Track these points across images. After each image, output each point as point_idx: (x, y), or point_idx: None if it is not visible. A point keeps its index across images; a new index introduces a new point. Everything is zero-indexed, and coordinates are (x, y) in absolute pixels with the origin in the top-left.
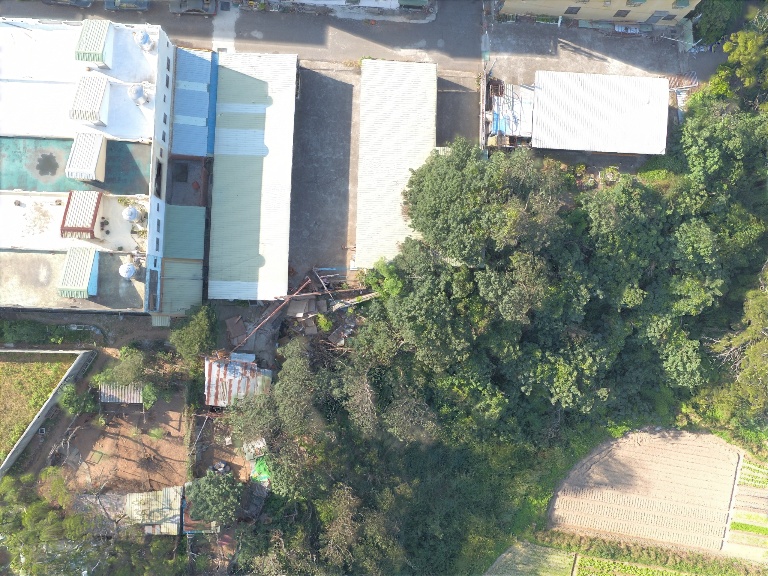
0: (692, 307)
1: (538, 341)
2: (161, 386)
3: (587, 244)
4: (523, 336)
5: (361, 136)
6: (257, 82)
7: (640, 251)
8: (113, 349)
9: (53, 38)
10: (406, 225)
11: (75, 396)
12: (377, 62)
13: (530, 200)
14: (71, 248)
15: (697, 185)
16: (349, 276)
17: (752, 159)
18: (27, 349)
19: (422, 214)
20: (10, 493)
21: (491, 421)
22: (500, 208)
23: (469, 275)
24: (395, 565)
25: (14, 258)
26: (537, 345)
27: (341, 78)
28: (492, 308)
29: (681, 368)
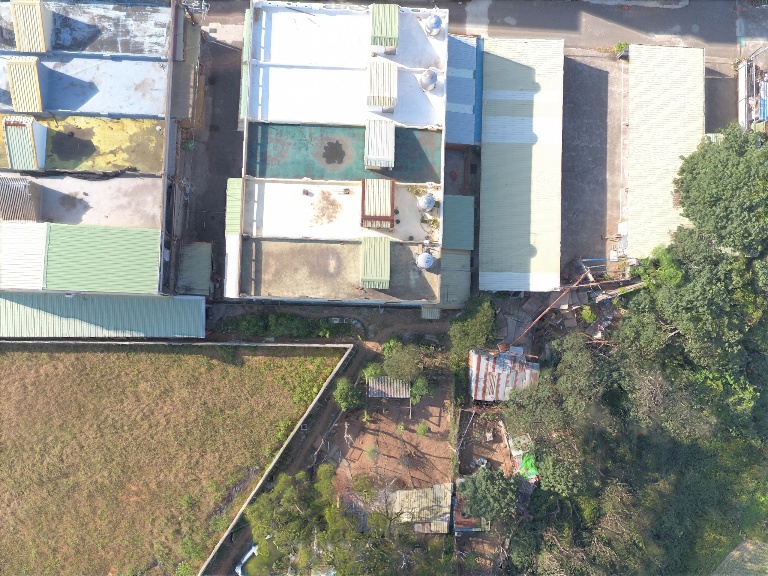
0: None
1: None
2: None
3: None
4: None
5: (631, 123)
6: (524, 68)
7: None
8: (373, 343)
9: (336, 23)
10: (677, 214)
11: (350, 391)
12: (644, 47)
13: None
14: (365, 238)
15: None
16: (609, 267)
17: None
18: (292, 343)
19: (699, 202)
20: (290, 490)
21: (740, 415)
22: None
23: None
24: None
25: (303, 249)
26: None
27: (596, 65)
28: (764, 298)
29: None
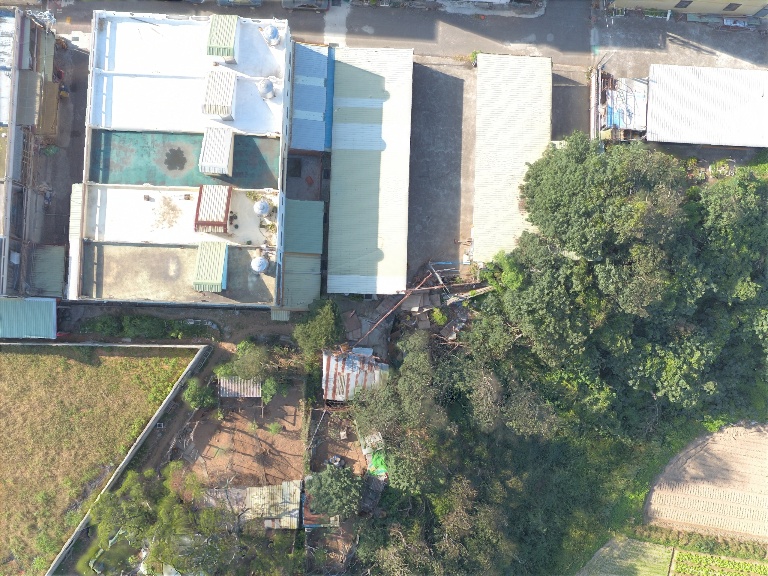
0: None
1: (646, 335)
2: (276, 380)
3: (700, 237)
4: None
5: (478, 130)
6: (374, 77)
7: (750, 244)
8: (229, 344)
9: (180, 33)
10: (523, 219)
11: (198, 390)
12: (492, 56)
13: (650, 193)
14: (202, 242)
15: None
16: (462, 270)
17: None
18: (146, 344)
19: (541, 208)
20: (136, 487)
21: (598, 415)
22: (623, 201)
23: (587, 268)
24: None
25: (144, 252)
26: (646, 339)
27: (452, 73)
28: (608, 301)
29: None
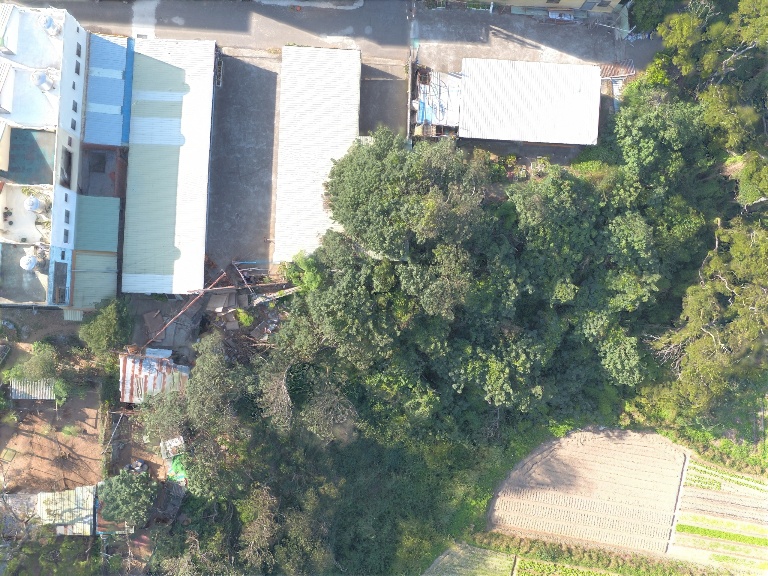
0: (627, 303)
1: (470, 337)
2: (77, 382)
3: (517, 237)
4: (456, 332)
5: (281, 125)
6: (174, 69)
7: (573, 245)
8: (27, 344)
9: None
10: (327, 217)
11: None
12: (298, 49)
13: (453, 191)
14: None
15: (631, 176)
16: (272, 270)
17: (692, 150)
18: None
19: (342, 205)
20: None
21: (422, 419)
22: (420, 199)
23: (391, 269)
24: (326, 567)
25: None
26: (468, 341)
27: (265, 66)
28: (416, 303)
29: (619, 366)
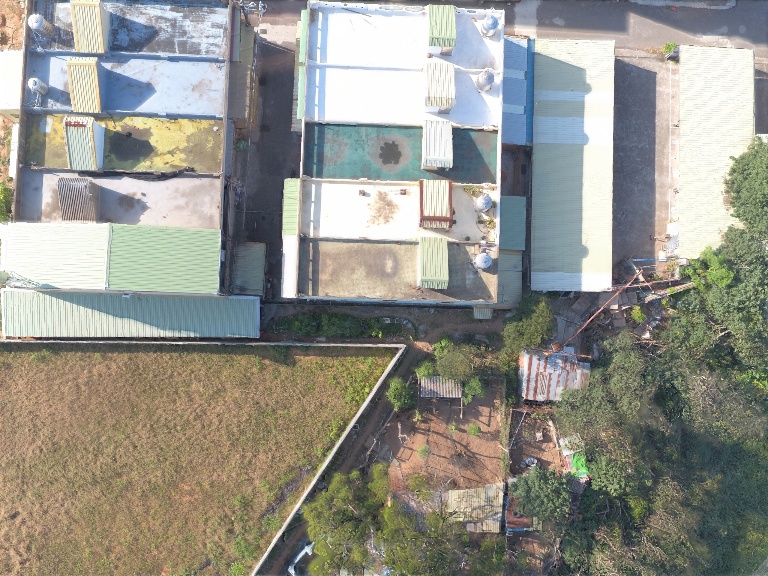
0: None
1: None
2: None
3: None
4: None
5: (681, 123)
6: (575, 69)
7: None
8: (424, 343)
9: (392, 24)
10: (728, 214)
11: (403, 391)
12: (694, 48)
13: None
14: (422, 238)
15: None
16: (658, 267)
17: None
18: (344, 343)
19: (750, 202)
20: (345, 490)
21: None
22: None
23: None
24: None
25: (360, 249)
26: None
27: (644, 65)
28: None
29: None
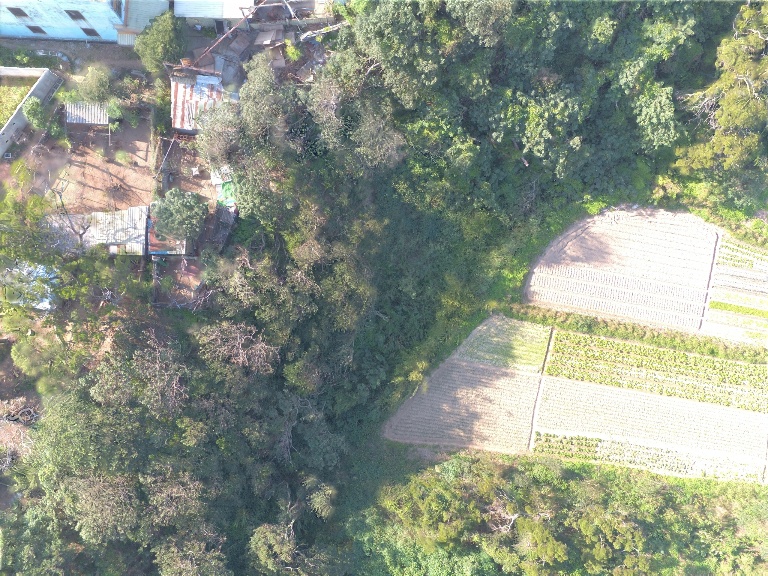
0: (663, 45)
1: (509, 86)
2: None
3: None
4: None
5: None
6: None
7: None
8: (80, 77)
9: None
10: None
11: (39, 107)
12: None
13: None
14: None
15: None
16: (317, 9)
17: None
18: None
19: None
20: None
21: (462, 170)
22: None
23: None
24: (367, 327)
25: None
26: (508, 87)
27: None
28: (460, 32)
29: (654, 119)
